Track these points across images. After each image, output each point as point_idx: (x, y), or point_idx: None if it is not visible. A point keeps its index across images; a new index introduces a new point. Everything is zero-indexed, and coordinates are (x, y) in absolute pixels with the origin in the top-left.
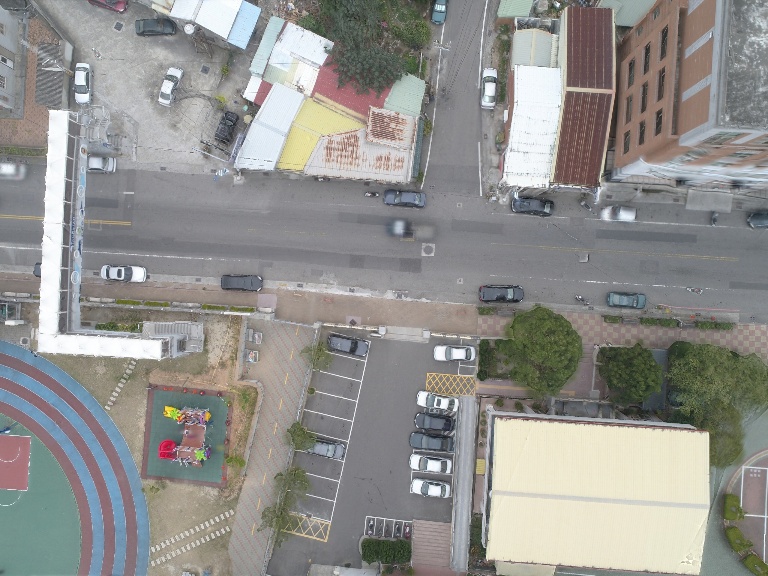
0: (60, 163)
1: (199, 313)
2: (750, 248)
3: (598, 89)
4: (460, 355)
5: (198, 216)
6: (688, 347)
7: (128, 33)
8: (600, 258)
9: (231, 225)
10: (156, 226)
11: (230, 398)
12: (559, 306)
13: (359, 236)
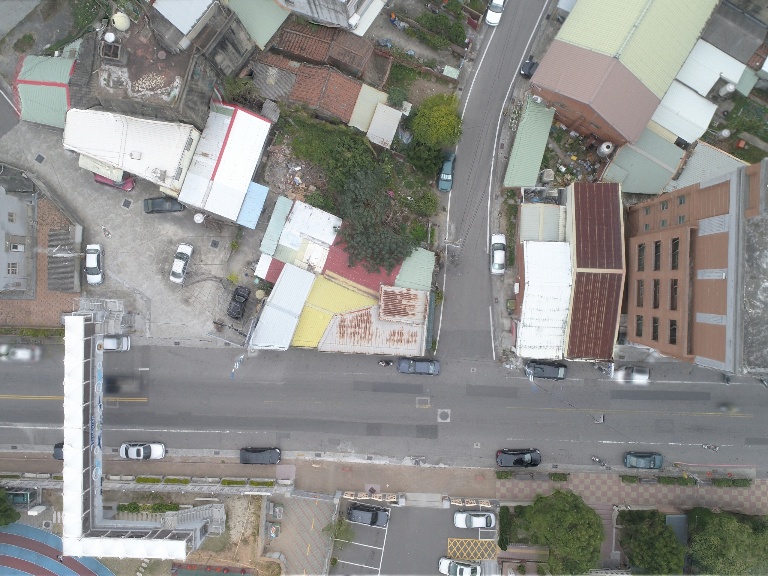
0: (78, 369)
1: None
2: (764, 405)
3: (608, 269)
4: (480, 523)
5: (214, 390)
6: (707, 516)
7: (137, 210)
8: (615, 418)
9: (247, 397)
10: (172, 401)
11: (254, 575)
12: (576, 467)
13: (375, 404)
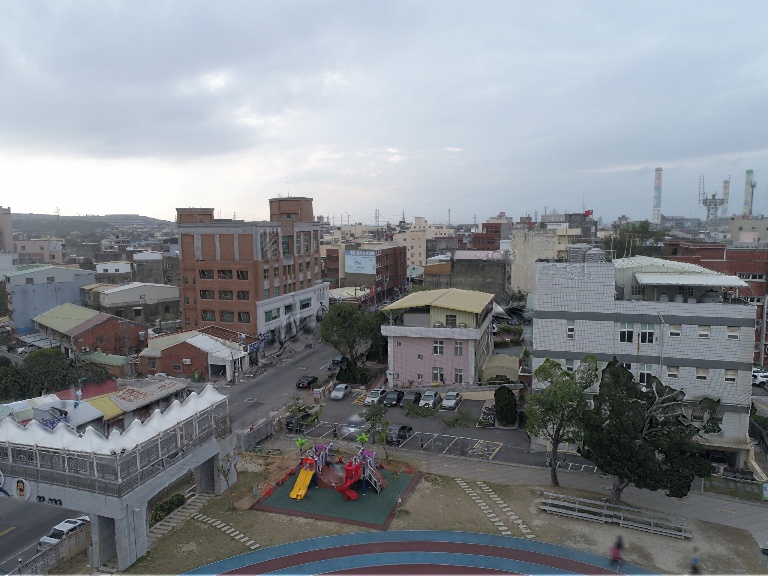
0: None
1: (193, 476)
2: None
3: None
4: None
5: None
6: None
7: None
8: None
9: None
10: (48, 510)
11: None
12: None
13: None
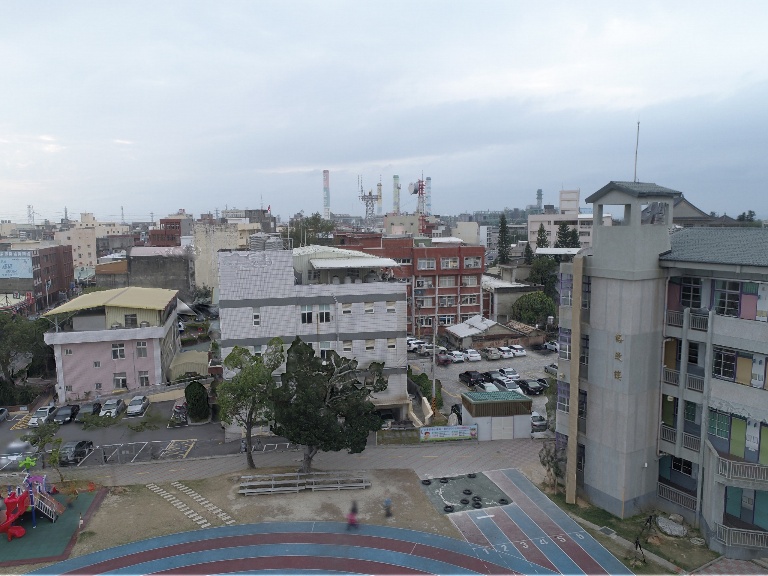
0: None
1: None
2: None
3: None
4: None
5: None
6: None
7: None
8: None
9: None
10: None
11: None
12: None
13: None
